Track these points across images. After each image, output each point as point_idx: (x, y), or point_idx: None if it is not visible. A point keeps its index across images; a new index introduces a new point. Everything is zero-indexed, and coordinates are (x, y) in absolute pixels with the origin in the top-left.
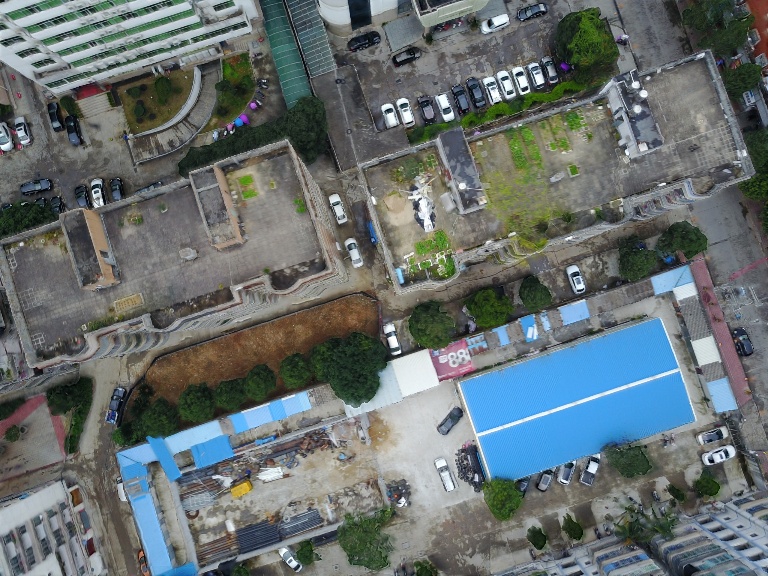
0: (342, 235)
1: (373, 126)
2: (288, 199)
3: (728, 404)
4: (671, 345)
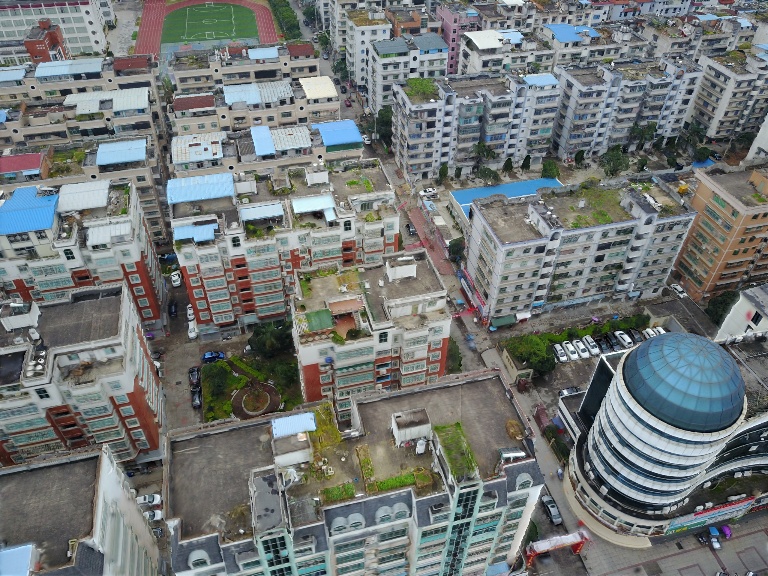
0: (671, 281)
1: (676, 318)
2: (733, 194)
3: (427, 202)
4: (465, 215)
